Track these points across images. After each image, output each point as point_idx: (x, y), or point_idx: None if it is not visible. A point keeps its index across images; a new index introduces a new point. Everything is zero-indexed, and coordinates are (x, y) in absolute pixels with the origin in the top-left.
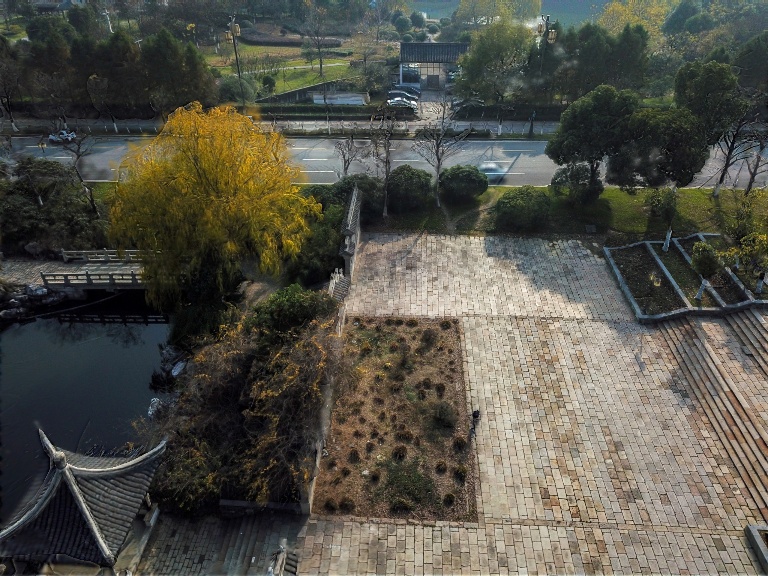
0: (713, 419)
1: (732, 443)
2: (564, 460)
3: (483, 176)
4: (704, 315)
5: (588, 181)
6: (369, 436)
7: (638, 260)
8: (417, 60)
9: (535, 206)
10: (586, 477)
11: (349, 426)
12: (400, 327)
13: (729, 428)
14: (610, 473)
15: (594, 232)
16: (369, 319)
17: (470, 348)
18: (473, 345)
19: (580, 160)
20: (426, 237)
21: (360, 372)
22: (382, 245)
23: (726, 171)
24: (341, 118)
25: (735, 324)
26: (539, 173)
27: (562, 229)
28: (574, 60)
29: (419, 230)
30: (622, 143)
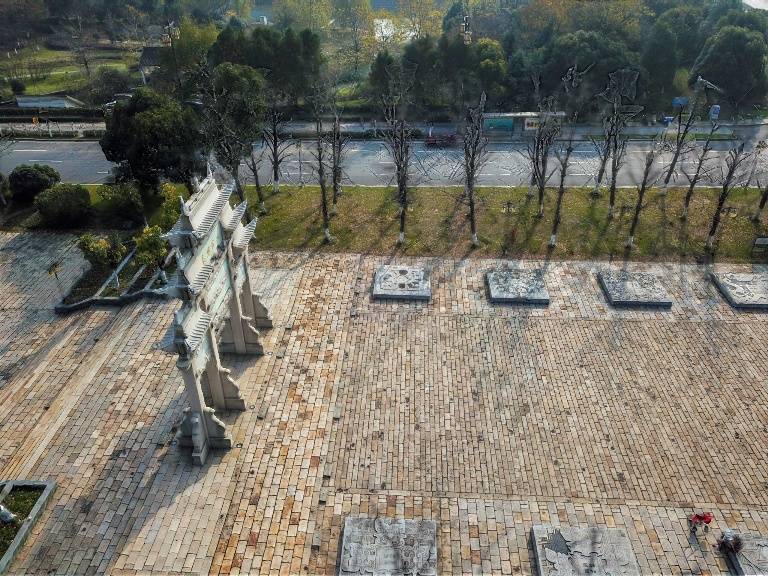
0: None
1: None
2: None
3: (48, 175)
4: (107, 304)
5: None
6: None
7: None
8: (155, 64)
9: (59, 203)
10: None
11: None
12: None
13: None
14: None
15: (129, 228)
16: None
17: None
18: None
19: (119, 159)
20: None
21: None
22: None
23: (277, 168)
24: (32, 120)
25: (121, 312)
26: None
27: (101, 225)
28: None
29: None
30: None
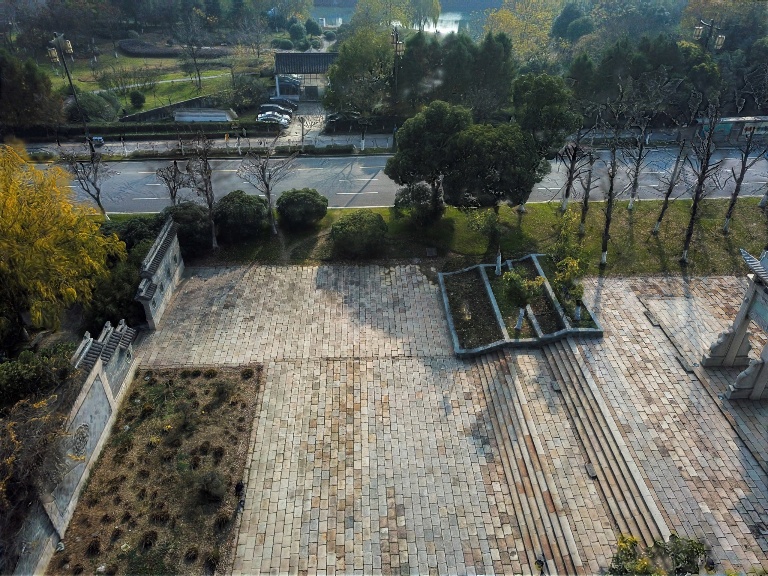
0: (507, 469)
1: (520, 497)
2: (335, 533)
3: (322, 199)
4: (522, 347)
5: (429, 201)
6: (119, 520)
7: (470, 286)
8: (292, 71)
9: (368, 232)
10: (354, 553)
11: (100, 509)
12: (196, 379)
13: (521, 479)
14: (382, 545)
15: (435, 255)
16: (163, 372)
17: (267, 400)
18: (271, 396)
19: (417, 180)
20: (255, 269)
21: (71, 460)
22: (204, 281)
23: (571, 185)
24: None
25: (550, 356)
26: (393, 191)
27: (402, 253)
28: (439, 70)
29: (250, 261)
30: (454, 162)
